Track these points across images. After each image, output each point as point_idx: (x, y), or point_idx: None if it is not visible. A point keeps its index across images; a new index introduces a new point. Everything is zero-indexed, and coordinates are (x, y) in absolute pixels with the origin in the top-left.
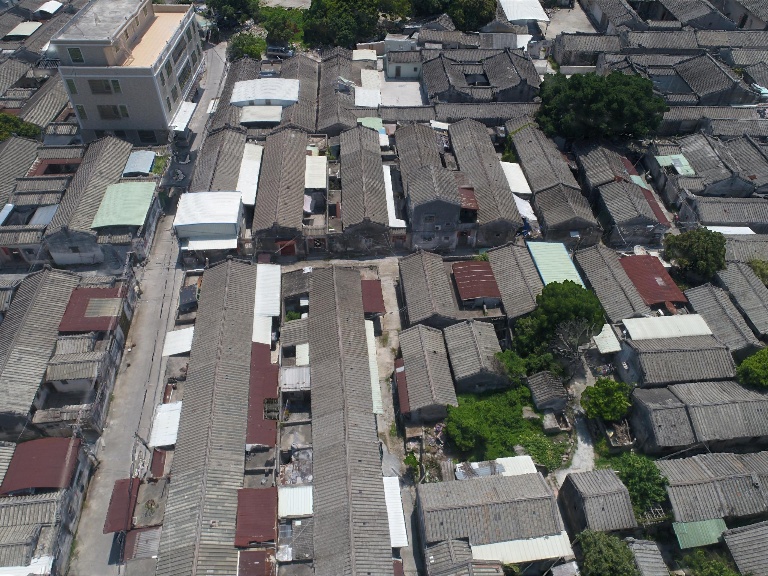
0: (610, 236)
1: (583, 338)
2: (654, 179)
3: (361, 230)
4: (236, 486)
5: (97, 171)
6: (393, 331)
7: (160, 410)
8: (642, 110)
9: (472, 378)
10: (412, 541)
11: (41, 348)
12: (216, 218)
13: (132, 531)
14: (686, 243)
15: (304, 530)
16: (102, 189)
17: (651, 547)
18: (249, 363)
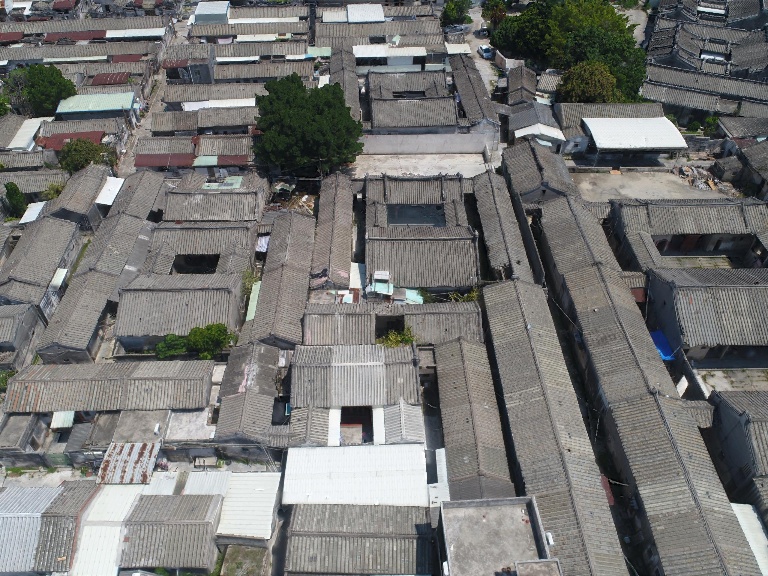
0: None
1: None
2: None
3: None
4: (26, 31)
5: None
6: None
7: None
8: None
9: None
10: None
11: None
12: (200, 9)
13: None
14: None
15: None
16: None
17: None
18: (91, 30)
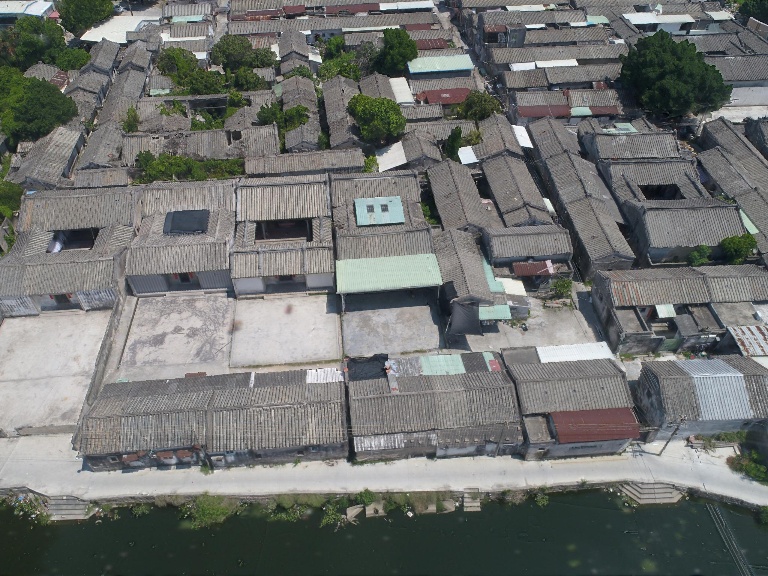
0: None
1: None
2: None
3: None
4: (306, 5)
5: None
6: None
7: None
8: None
9: None
10: None
11: None
12: None
13: None
14: None
15: None
16: None
17: (272, 76)
18: (366, 3)
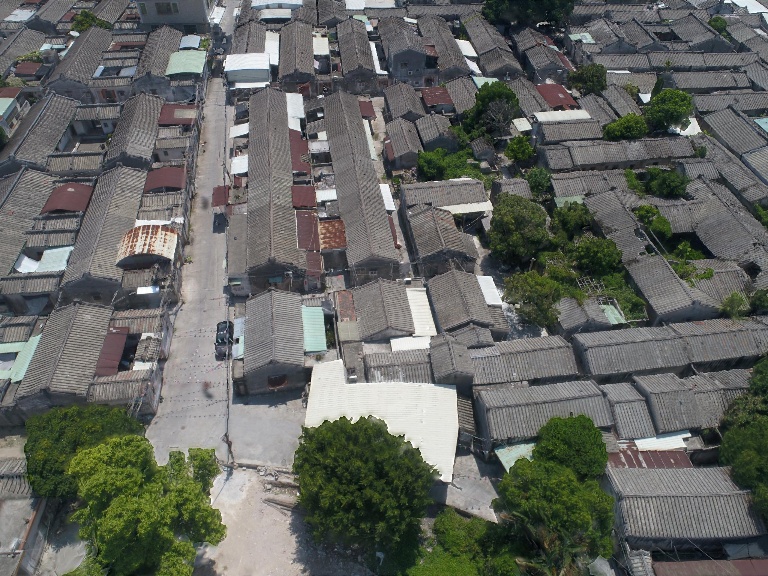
0: (533, 81)
1: (506, 119)
2: (569, 52)
3: (356, 75)
4: (289, 185)
5: (161, 45)
6: (382, 133)
7: (234, 159)
8: (558, 0)
9: (434, 142)
10: (398, 220)
11: (150, 131)
12: (254, 66)
13: (229, 206)
14: (579, 72)
15: (333, 206)
16: (167, 55)
17: (540, 206)
18: (288, 137)
